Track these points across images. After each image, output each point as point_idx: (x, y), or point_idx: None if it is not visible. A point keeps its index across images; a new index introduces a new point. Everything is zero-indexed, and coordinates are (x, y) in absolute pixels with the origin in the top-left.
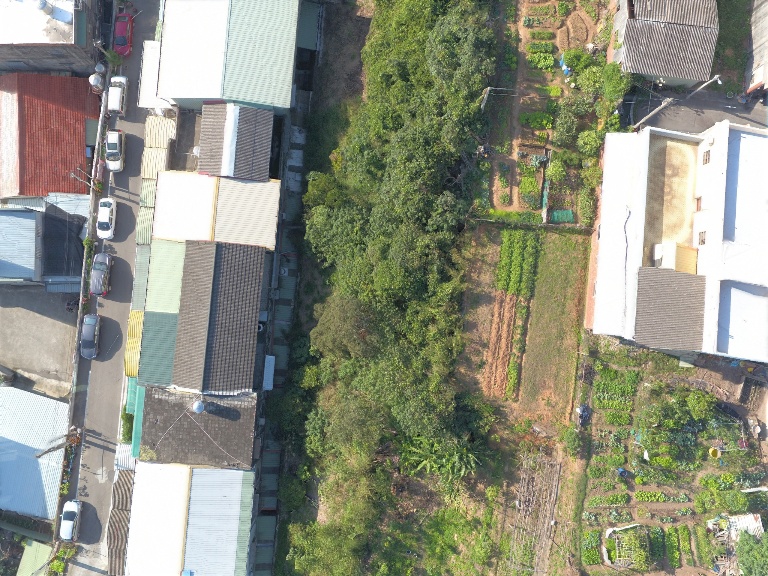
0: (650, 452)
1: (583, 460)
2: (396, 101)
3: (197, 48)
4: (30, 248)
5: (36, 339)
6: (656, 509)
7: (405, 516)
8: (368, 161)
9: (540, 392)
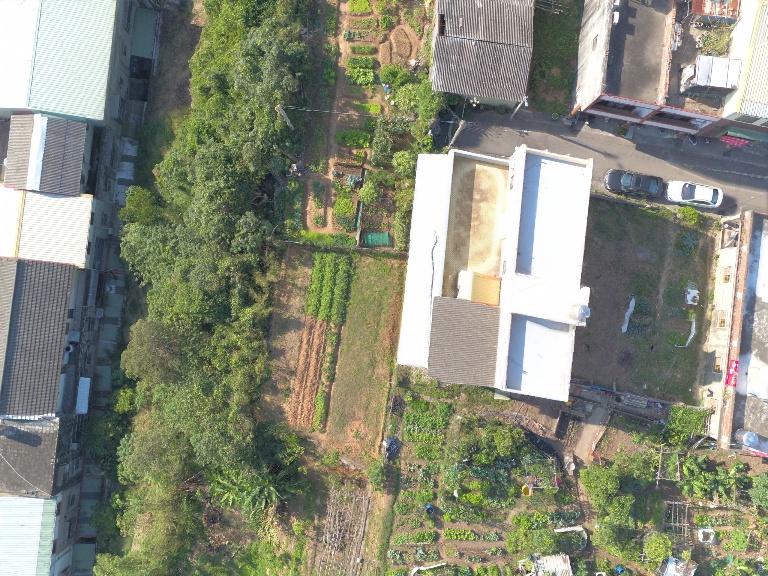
0: (461, 488)
1: (390, 495)
2: (209, 115)
3: (5, 55)
4: None
5: None
6: (465, 548)
7: (216, 548)
8: (178, 177)
9: (349, 423)
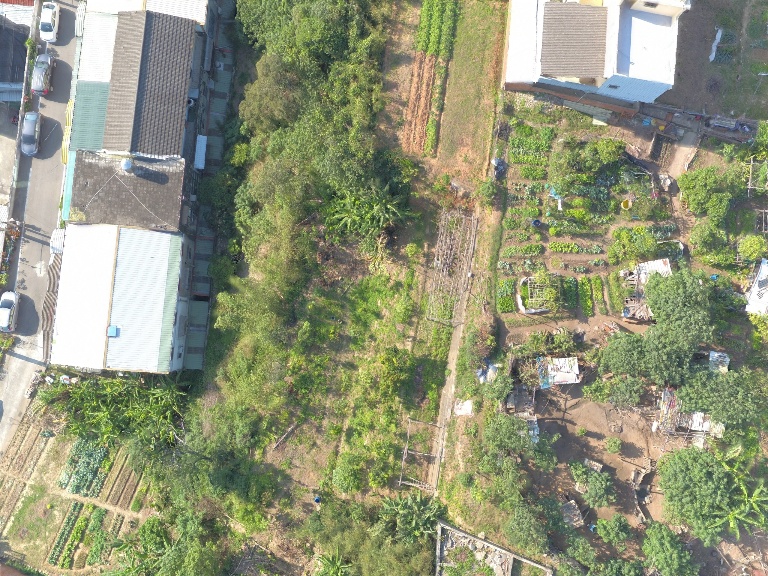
0: (564, 205)
1: (498, 212)
2: None
3: None
4: None
5: None
6: (570, 260)
7: (330, 283)
8: None
9: (458, 149)
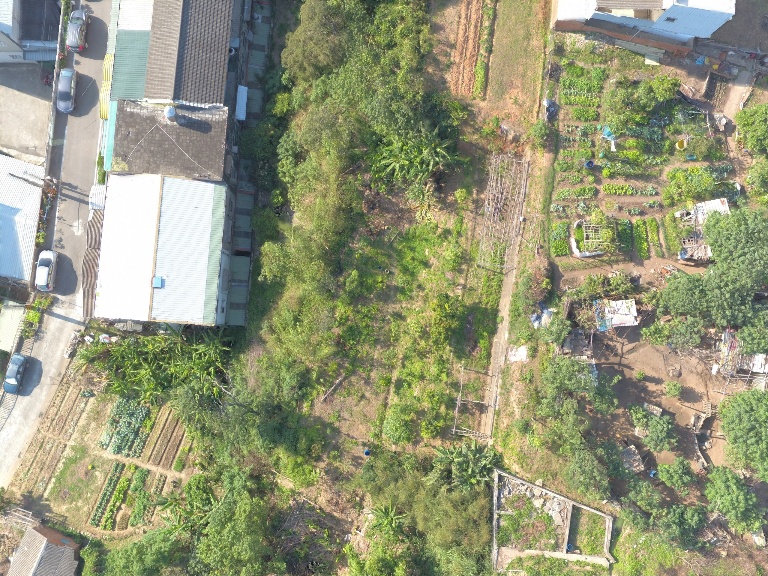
0: (617, 146)
1: (550, 154)
2: None
3: None
4: (8, 5)
5: (15, 115)
6: (624, 202)
7: (376, 233)
8: None
9: (507, 91)
